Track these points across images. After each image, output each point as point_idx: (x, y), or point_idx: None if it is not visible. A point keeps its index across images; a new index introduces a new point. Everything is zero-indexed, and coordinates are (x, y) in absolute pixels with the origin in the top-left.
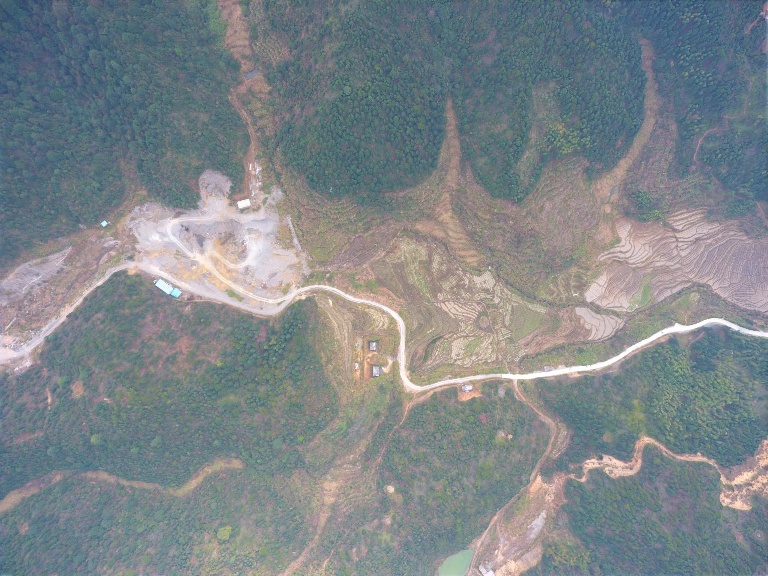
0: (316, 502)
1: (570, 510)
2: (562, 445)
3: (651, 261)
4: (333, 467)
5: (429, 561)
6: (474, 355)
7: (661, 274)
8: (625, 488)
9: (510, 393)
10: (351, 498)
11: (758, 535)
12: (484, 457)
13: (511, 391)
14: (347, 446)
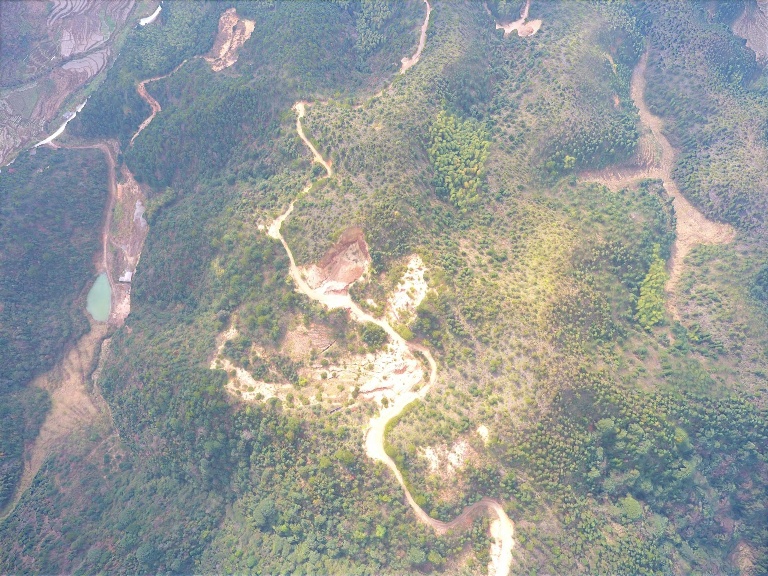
0: None
1: (138, 176)
2: (120, 152)
3: (93, 1)
4: None
5: (63, 306)
6: None
7: (110, 3)
8: None
9: (44, 149)
10: None
11: None
12: (20, 188)
13: (45, 148)
14: None
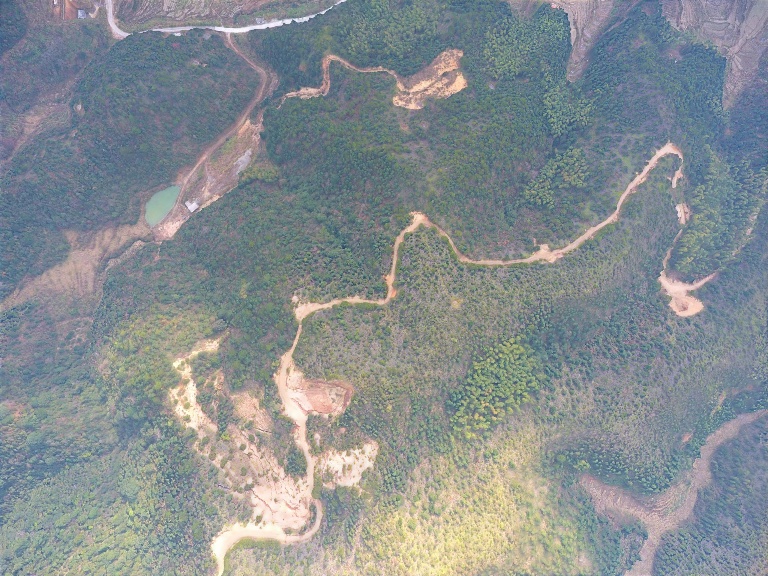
0: (13, 128)
1: (264, 134)
2: (272, 92)
3: None
4: (37, 104)
5: (130, 190)
6: (186, 8)
7: None
8: (308, 100)
9: (218, 39)
10: (48, 124)
11: (423, 125)
12: (168, 71)
13: (220, 38)
14: (49, 82)
